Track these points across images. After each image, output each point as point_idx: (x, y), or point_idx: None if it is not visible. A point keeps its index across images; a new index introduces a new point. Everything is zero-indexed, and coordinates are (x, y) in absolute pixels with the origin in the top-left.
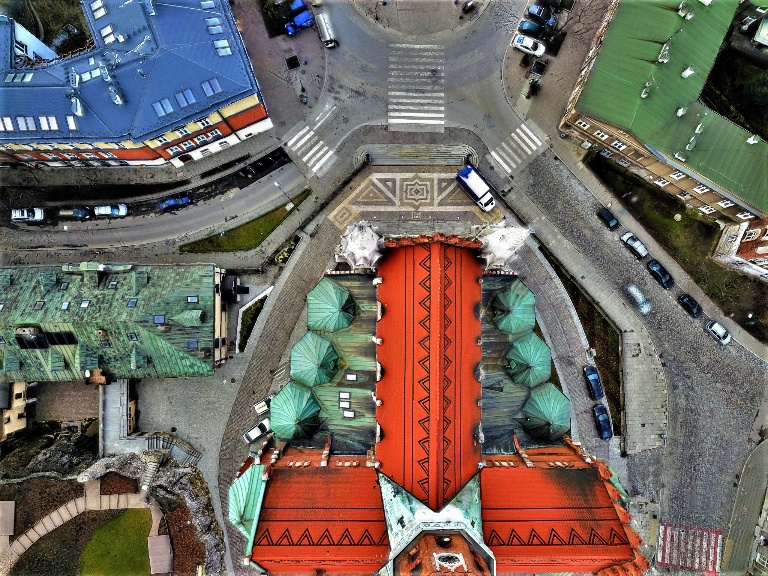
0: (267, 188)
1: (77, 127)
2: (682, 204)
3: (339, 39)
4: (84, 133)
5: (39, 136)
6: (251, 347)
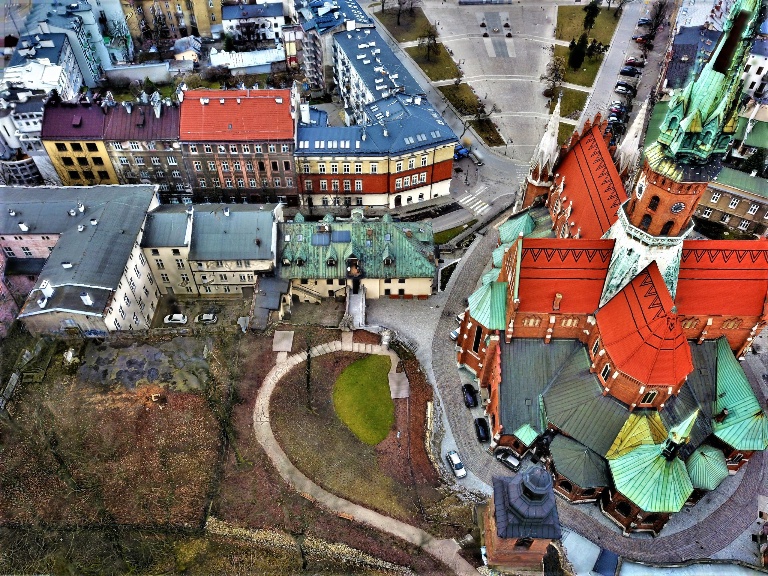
0: (449, 219)
1: (360, 147)
2: (726, 228)
3: (484, 162)
4: (363, 150)
5: (337, 151)
6: (449, 288)
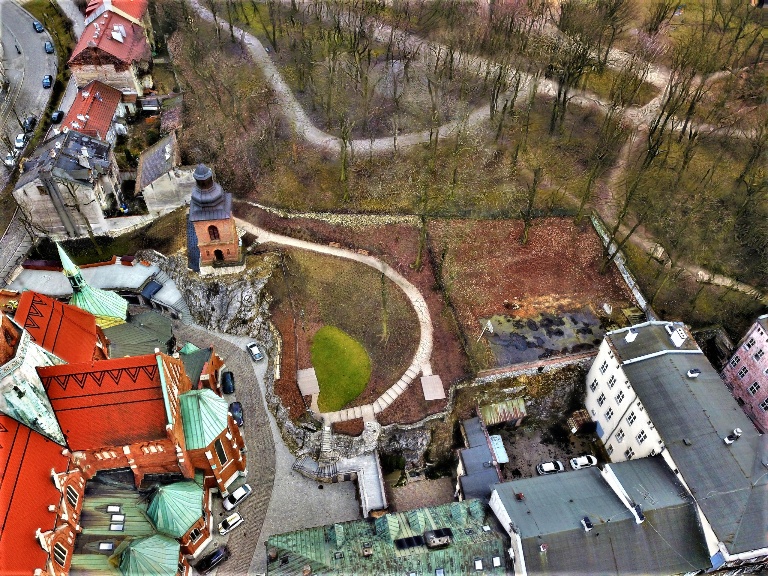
0: None
1: None
2: None
3: None
4: None
5: None
6: None
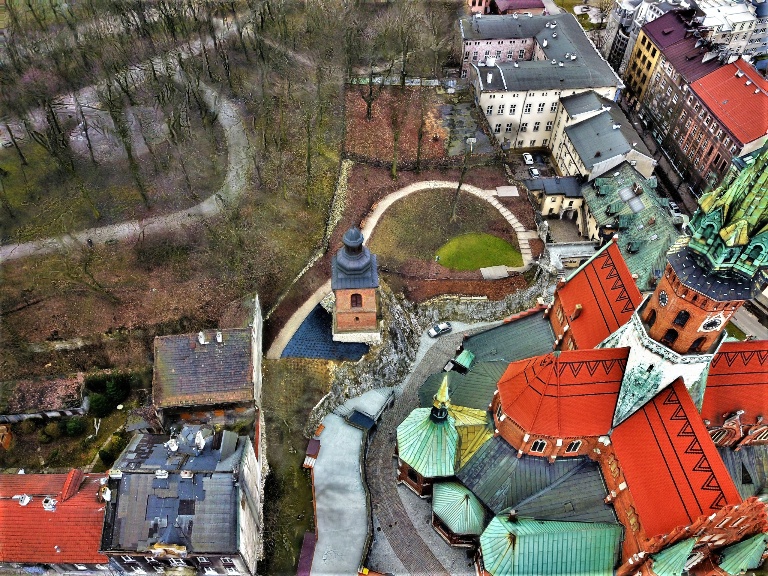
0: None
1: None
2: None
3: None
4: None
5: None
6: None
